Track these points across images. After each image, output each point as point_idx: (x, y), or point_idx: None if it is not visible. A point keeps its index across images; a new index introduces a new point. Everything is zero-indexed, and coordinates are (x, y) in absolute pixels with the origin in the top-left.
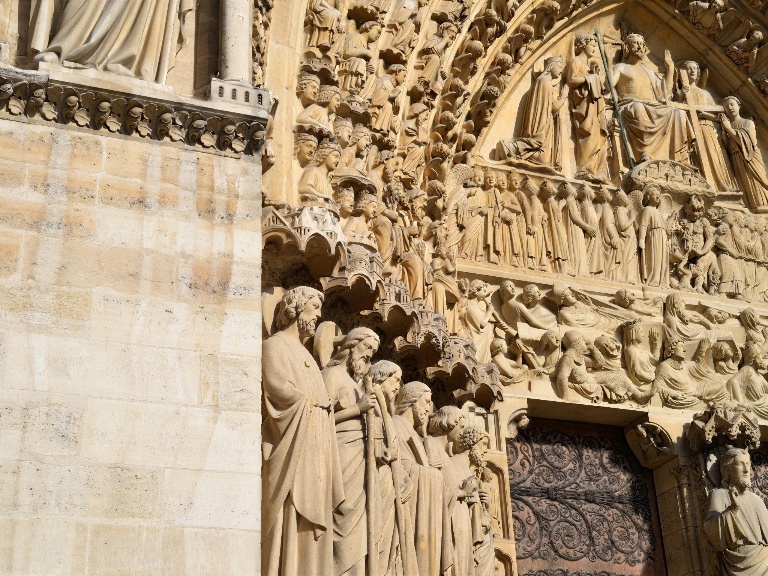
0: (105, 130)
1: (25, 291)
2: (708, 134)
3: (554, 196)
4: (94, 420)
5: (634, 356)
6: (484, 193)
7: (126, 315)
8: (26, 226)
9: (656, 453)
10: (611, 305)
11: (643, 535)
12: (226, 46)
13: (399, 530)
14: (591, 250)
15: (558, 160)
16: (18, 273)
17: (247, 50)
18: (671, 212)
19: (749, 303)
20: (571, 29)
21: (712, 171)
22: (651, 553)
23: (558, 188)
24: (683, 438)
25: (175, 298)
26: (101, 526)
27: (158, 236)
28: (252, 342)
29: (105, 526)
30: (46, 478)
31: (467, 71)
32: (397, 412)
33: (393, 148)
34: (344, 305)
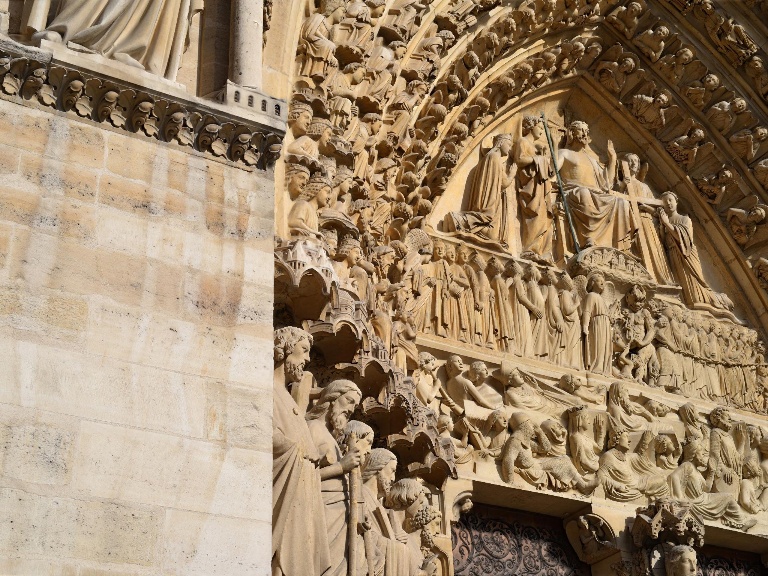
0: (108, 124)
1: (13, 291)
2: (648, 227)
3: (500, 274)
4: (87, 446)
5: (580, 443)
6: (432, 264)
7: (126, 329)
8: (17, 218)
9: (597, 547)
10: (557, 389)
11: None
12: (239, 51)
13: None
14: (537, 332)
15: (505, 238)
16: (6, 270)
17: (261, 59)
18: (613, 300)
19: (687, 398)
20: (519, 109)
21: (652, 263)
22: None
23: (505, 266)
24: (625, 532)
25: (180, 316)
26: (91, 571)
27: (163, 245)
28: (263, 373)
29: (96, 572)
30: (29, 510)
31: (428, 135)
32: None
33: (367, 198)
34: (318, 356)
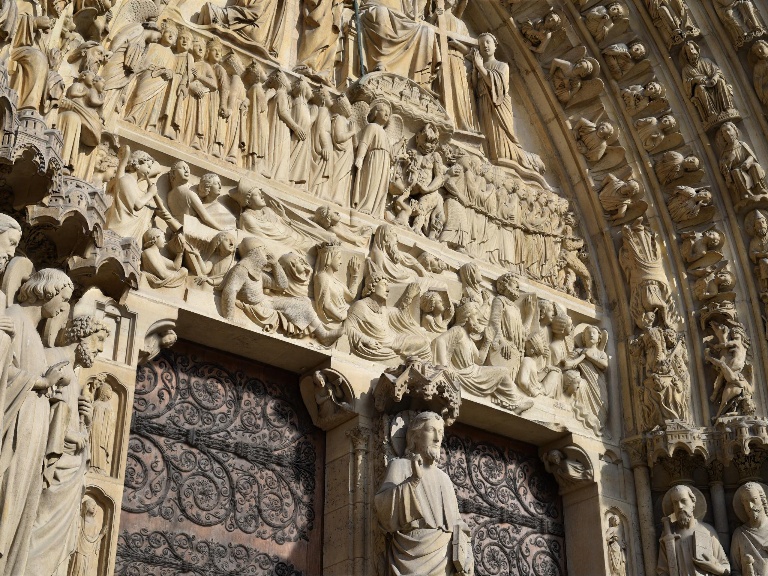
0: None
1: None
2: (456, 66)
3: (262, 84)
4: None
5: (325, 284)
6: (174, 56)
7: None
8: None
9: (333, 409)
10: (308, 221)
11: (300, 508)
12: None
13: None
14: (296, 155)
15: (275, 45)
16: None
17: None
18: (400, 138)
19: (472, 258)
20: None
21: (454, 106)
22: (306, 532)
23: (269, 75)
24: (368, 395)
25: None
26: None
27: None
28: None
29: None
30: None
31: None
32: None
33: None
34: None
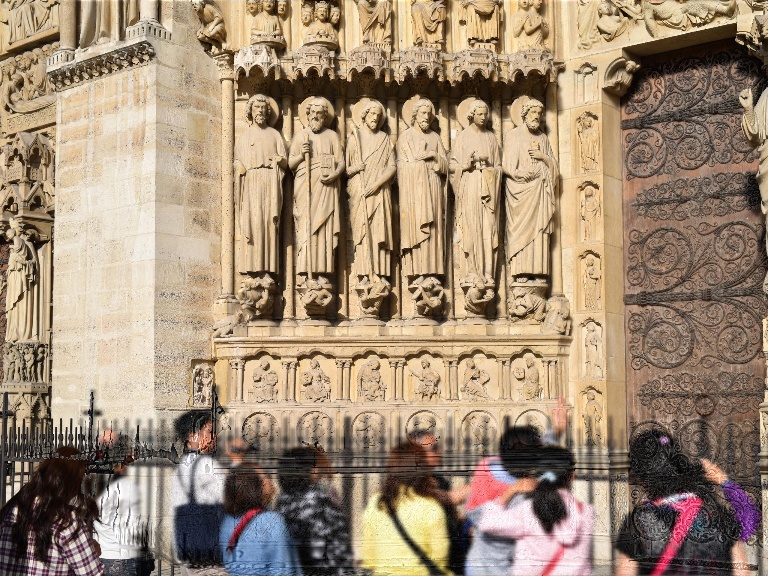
0: None
1: None
2: None
3: None
4: (105, 221)
5: None
6: None
7: None
8: None
9: None
10: None
11: None
12: None
13: None
14: None
15: None
16: None
17: None
18: None
19: None
20: None
21: None
22: None
23: None
24: None
25: None
26: None
27: None
28: None
29: None
30: None
31: None
32: (411, 125)
33: None
34: None
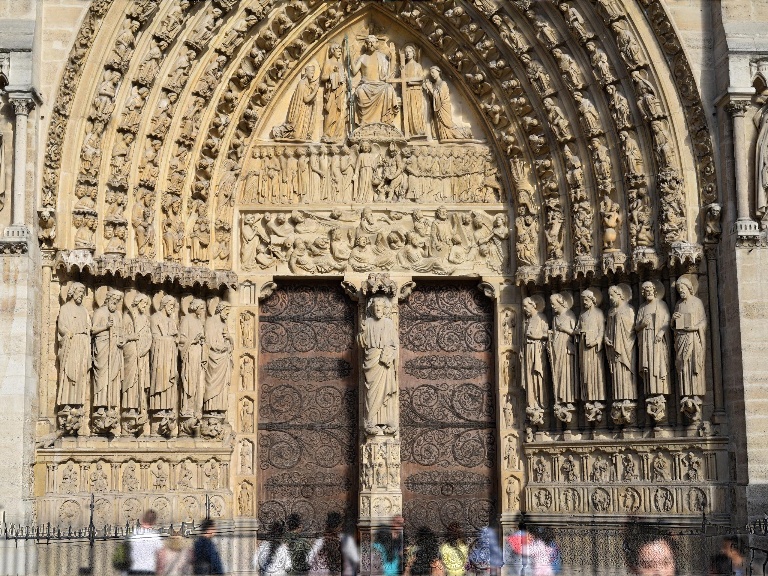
0: None
1: None
2: (414, 96)
3: (305, 154)
4: None
5: (334, 248)
6: (260, 161)
7: None
8: None
9: None
10: (327, 219)
11: (348, 337)
12: (14, 209)
13: (138, 369)
14: (323, 185)
15: (309, 132)
16: None
17: (23, 208)
18: None
19: (421, 204)
20: (327, 42)
21: (412, 121)
22: (351, 346)
23: None
24: None
25: None
26: None
27: None
28: (23, 329)
29: None
30: None
31: (229, 108)
32: (159, 310)
33: (153, 186)
34: None
